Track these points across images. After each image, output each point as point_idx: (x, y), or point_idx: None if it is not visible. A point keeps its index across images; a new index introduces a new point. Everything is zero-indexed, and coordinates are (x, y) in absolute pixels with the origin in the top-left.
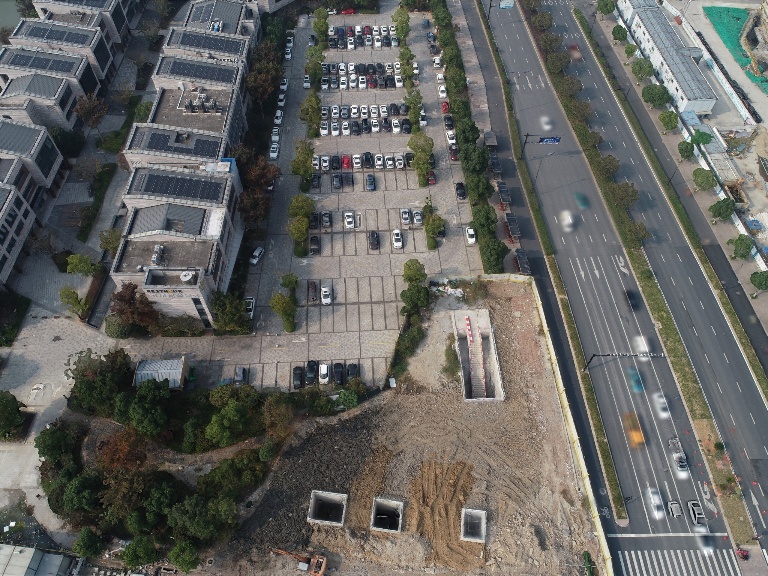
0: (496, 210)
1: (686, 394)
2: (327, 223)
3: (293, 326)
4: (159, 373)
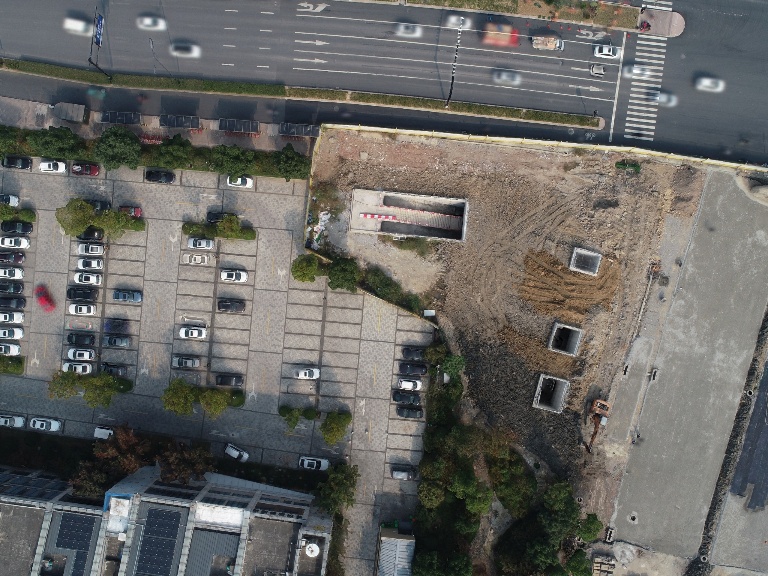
0: (200, 138)
1: (489, 7)
2: (196, 362)
3: (347, 415)
4: (398, 563)
